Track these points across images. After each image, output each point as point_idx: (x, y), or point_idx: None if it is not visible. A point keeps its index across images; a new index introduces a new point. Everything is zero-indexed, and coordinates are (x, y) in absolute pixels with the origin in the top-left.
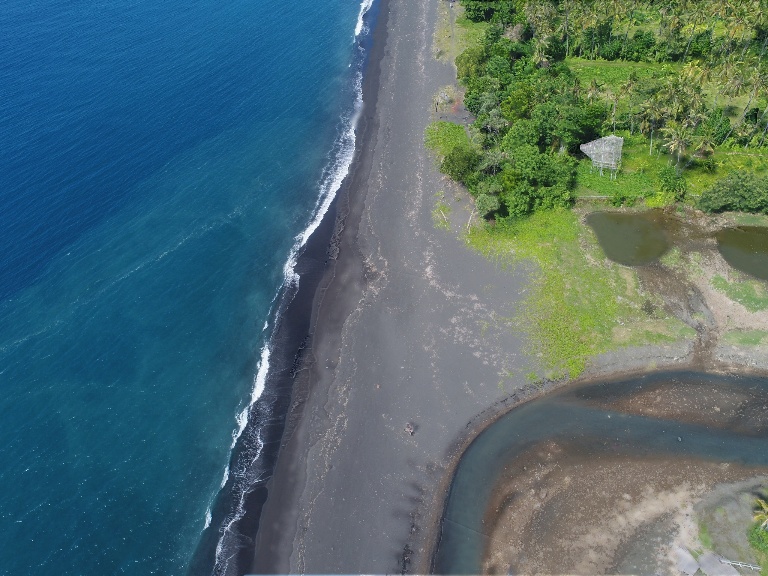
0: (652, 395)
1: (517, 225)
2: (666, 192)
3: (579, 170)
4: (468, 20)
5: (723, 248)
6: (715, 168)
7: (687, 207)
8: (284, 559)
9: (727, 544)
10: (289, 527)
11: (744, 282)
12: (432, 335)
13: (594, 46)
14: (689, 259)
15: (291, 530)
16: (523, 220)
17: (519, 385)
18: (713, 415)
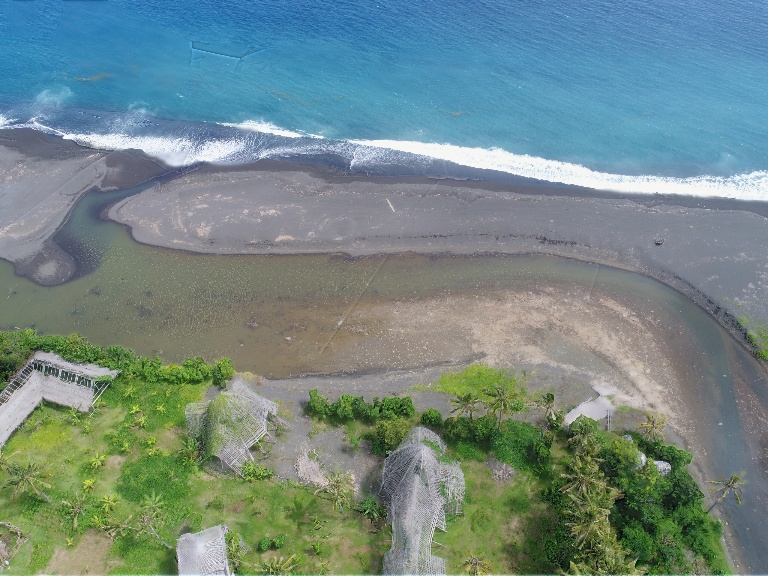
0: (765, 415)
1: None
2: None
3: None
4: None
5: None
6: None
7: None
8: (555, 194)
9: (624, 416)
10: (574, 194)
11: None
12: (759, 258)
13: None
14: None
15: (572, 195)
16: None
17: (730, 310)
18: (761, 461)
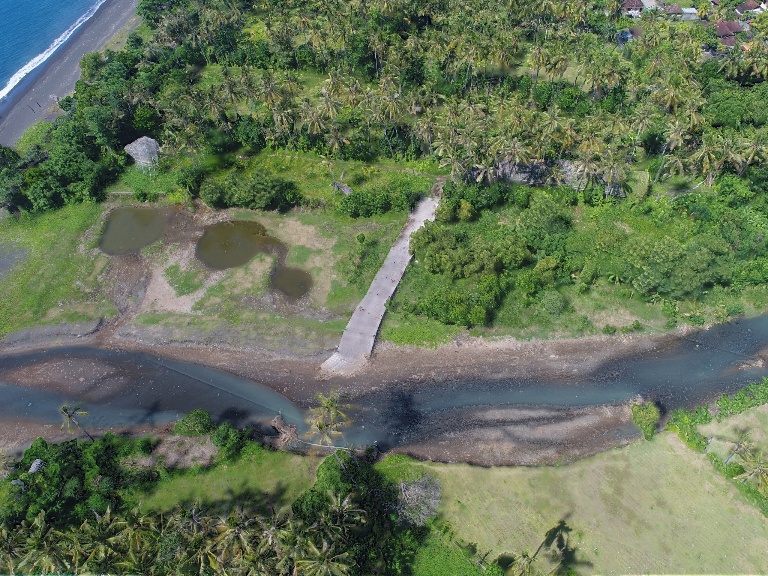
0: (38, 367)
1: (40, 217)
2: (183, 189)
3: (131, 168)
4: (148, 27)
5: (204, 240)
6: (244, 168)
7: (203, 203)
8: None
9: None
10: None
11: (193, 270)
12: None
13: (224, 54)
14: (166, 249)
15: None
16: (49, 213)
17: None
18: (74, 384)
